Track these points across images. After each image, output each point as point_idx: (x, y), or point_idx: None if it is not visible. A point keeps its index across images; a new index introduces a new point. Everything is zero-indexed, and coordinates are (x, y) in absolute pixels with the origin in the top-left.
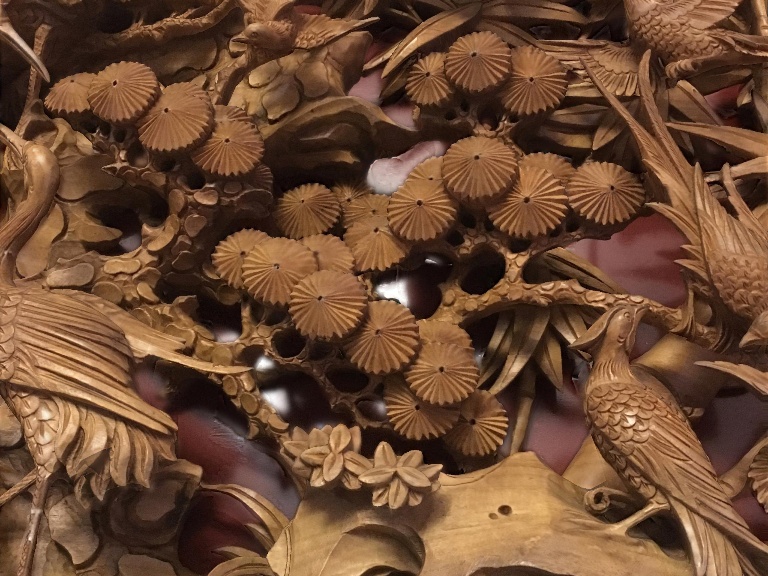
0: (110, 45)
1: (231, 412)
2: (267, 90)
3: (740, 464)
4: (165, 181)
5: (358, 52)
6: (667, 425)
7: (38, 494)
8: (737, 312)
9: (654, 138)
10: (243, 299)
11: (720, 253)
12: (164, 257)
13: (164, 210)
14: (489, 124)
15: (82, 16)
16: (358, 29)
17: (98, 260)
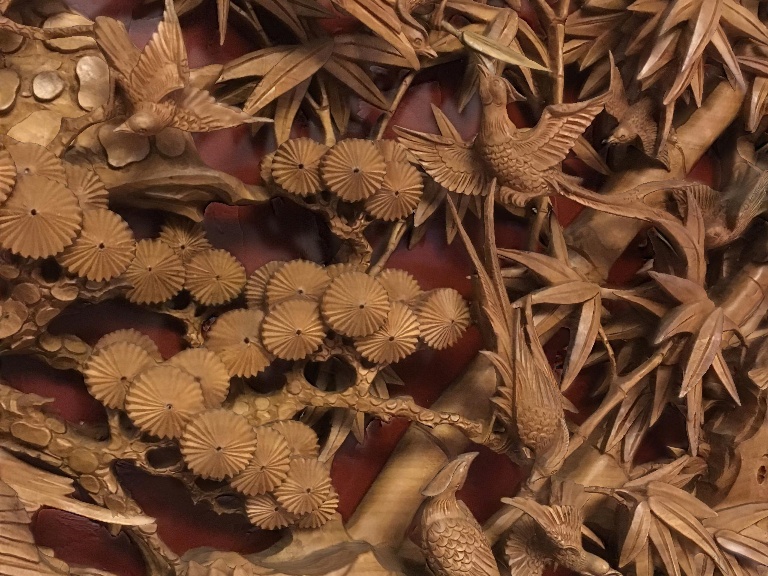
0: None
1: None
2: None
3: (493, 528)
4: (18, 275)
5: (209, 88)
6: (482, 555)
7: None
8: (526, 444)
9: (491, 281)
10: None
11: (527, 403)
12: (2, 340)
13: (1, 287)
14: (346, 217)
15: None
16: (189, 20)
17: None
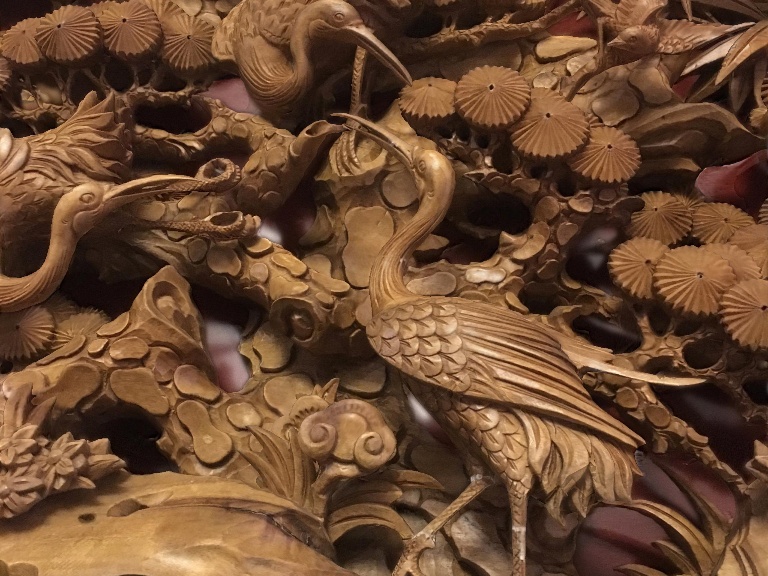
0: (419, 50)
1: (632, 425)
2: (596, 96)
3: None
4: (538, 188)
5: (685, 58)
6: None
7: (520, 511)
8: None
9: None
10: (635, 309)
11: None
12: (529, 266)
13: (524, 218)
14: None
15: (402, 20)
16: None
17: (455, 269)
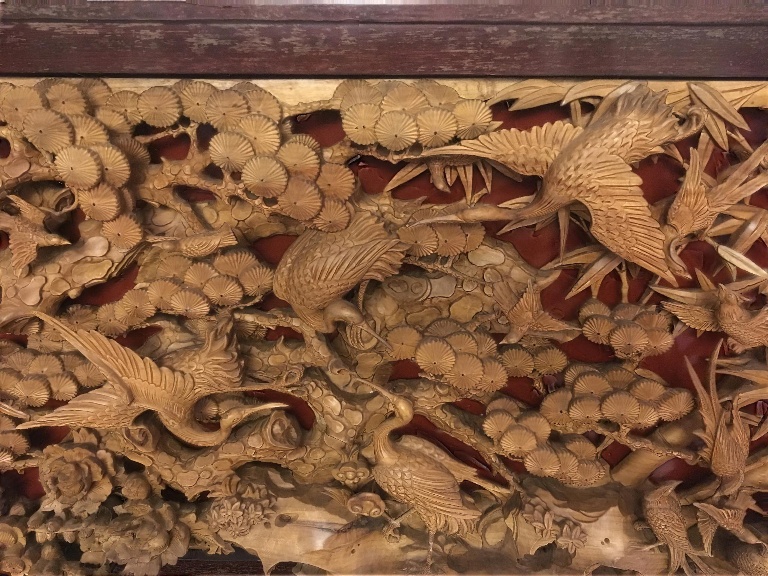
0: None
1: (484, 463)
2: None
3: (695, 495)
4: None
5: None
6: None
7: (432, 539)
8: None
9: (708, 395)
10: None
11: (719, 460)
12: None
13: None
14: None
15: None
16: (546, 230)
17: (412, 396)
